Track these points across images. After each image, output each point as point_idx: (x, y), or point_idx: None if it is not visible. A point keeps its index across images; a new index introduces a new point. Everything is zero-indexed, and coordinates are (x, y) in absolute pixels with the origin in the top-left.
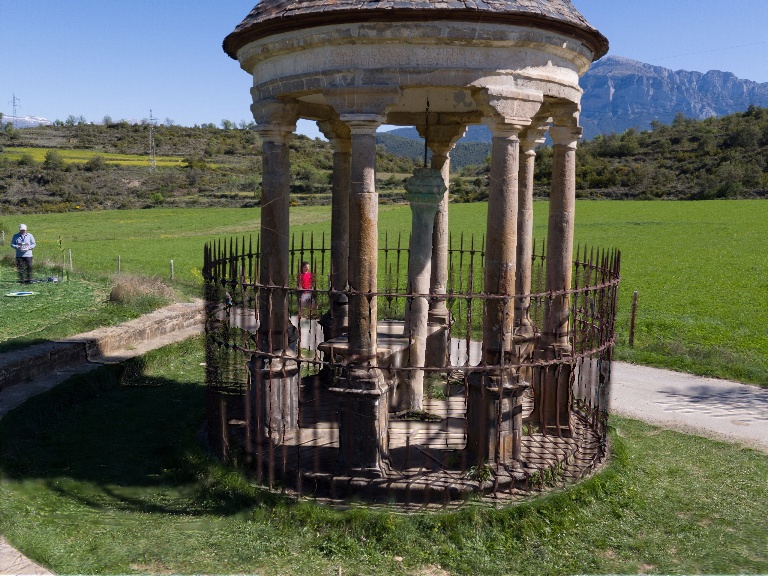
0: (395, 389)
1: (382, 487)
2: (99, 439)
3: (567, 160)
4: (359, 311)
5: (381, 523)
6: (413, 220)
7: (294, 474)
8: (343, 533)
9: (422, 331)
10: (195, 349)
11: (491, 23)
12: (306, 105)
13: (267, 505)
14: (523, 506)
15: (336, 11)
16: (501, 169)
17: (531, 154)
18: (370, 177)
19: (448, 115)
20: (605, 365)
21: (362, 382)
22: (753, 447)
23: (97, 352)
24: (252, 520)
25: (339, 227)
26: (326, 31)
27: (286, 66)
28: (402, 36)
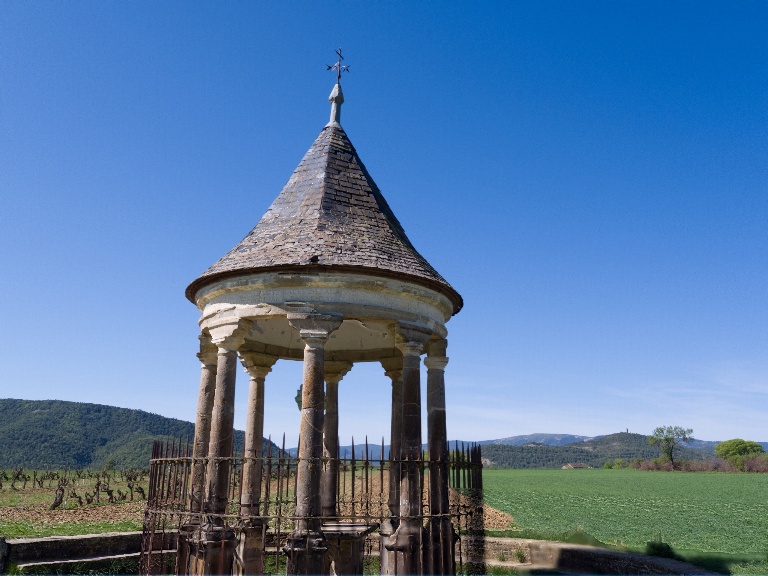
0: None
1: None
2: None
3: None
4: None
5: None
6: None
7: None
8: None
9: None
10: None
11: None
12: None
13: None
14: None
15: None
16: None
17: None
18: None
19: None
20: None
21: None
22: None
23: None
24: None
25: None
26: None
27: None
28: None
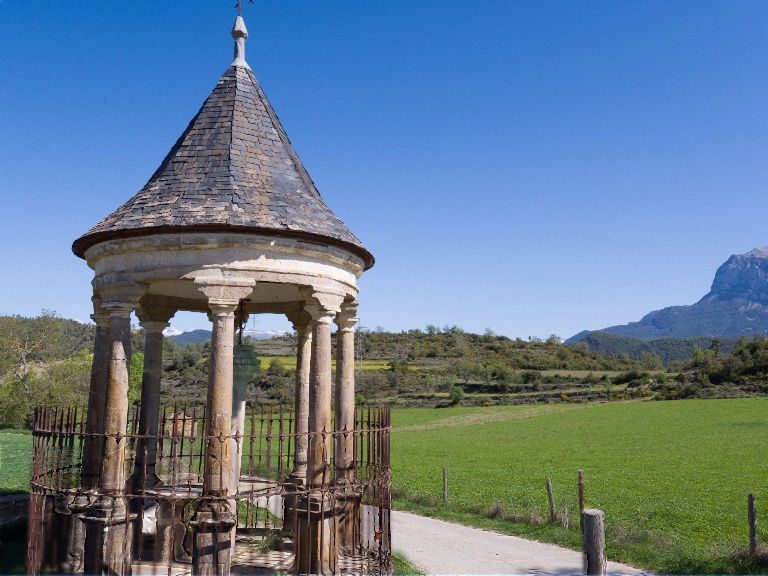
0: None
1: None
2: None
3: (318, 332)
4: (104, 452)
5: None
6: None
7: None
8: None
9: (230, 483)
10: None
11: (192, 233)
12: (186, 301)
13: None
14: None
15: (95, 234)
16: (214, 339)
17: (346, 331)
18: (118, 348)
19: None
20: (529, 546)
21: (98, 511)
22: None
23: None
24: None
25: None
26: (97, 248)
27: None
28: (132, 247)
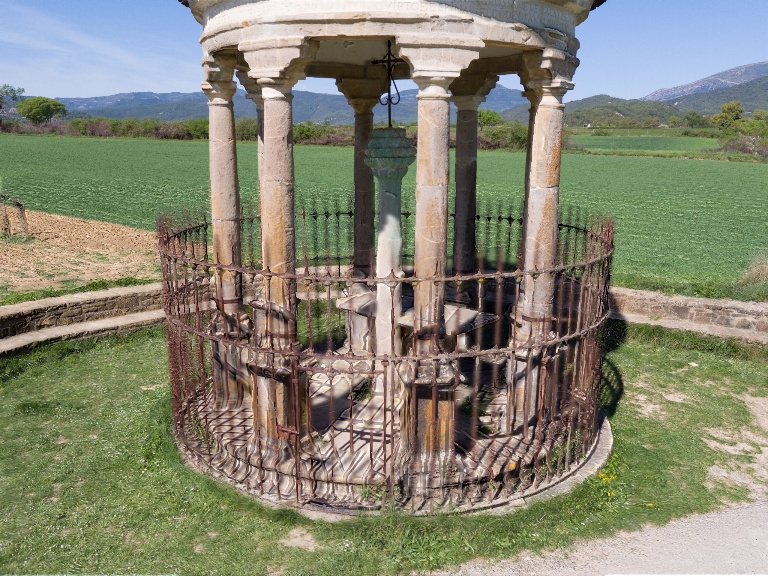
0: None
1: None
2: None
3: None
4: None
5: None
6: None
7: None
8: None
9: None
10: (734, 353)
11: None
12: (497, 60)
13: None
14: (162, 398)
15: None
16: None
17: None
18: None
19: None
20: None
21: None
22: None
23: (610, 305)
24: None
25: None
26: None
27: None
28: None
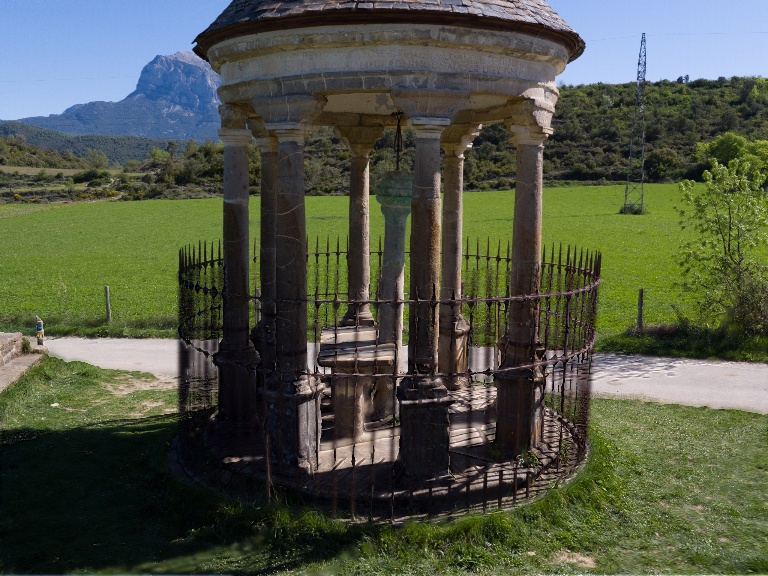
0: (373, 396)
1: (463, 492)
2: (48, 516)
3: None
4: (428, 319)
5: (498, 525)
6: (388, 224)
7: (365, 499)
8: (469, 544)
9: None
10: (30, 388)
11: (543, 39)
12: None
13: (371, 537)
14: (586, 480)
15: (423, 10)
16: (532, 175)
17: (462, 158)
18: (438, 182)
19: (371, 117)
20: None
21: (435, 391)
22: (648, 400)
23: None
24: (364, 556)
25: (272, 233)
26: (401, 29)
27: (333, 61)
28: (478, 43)
